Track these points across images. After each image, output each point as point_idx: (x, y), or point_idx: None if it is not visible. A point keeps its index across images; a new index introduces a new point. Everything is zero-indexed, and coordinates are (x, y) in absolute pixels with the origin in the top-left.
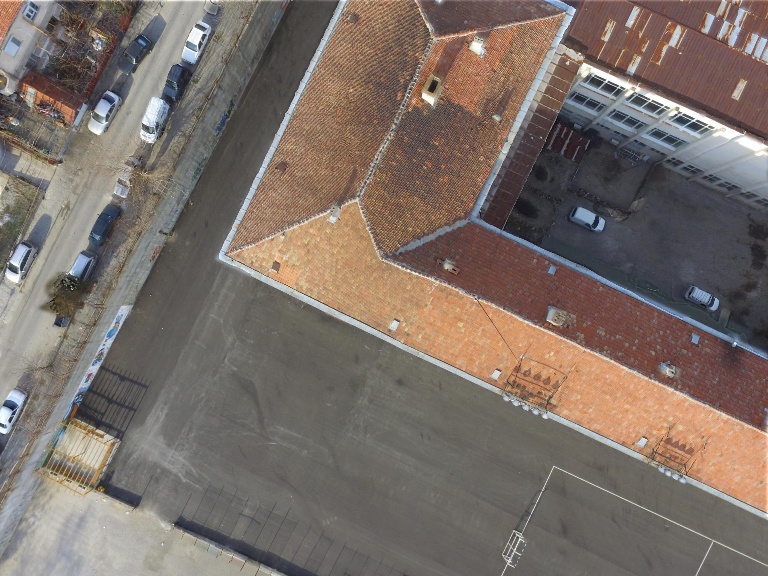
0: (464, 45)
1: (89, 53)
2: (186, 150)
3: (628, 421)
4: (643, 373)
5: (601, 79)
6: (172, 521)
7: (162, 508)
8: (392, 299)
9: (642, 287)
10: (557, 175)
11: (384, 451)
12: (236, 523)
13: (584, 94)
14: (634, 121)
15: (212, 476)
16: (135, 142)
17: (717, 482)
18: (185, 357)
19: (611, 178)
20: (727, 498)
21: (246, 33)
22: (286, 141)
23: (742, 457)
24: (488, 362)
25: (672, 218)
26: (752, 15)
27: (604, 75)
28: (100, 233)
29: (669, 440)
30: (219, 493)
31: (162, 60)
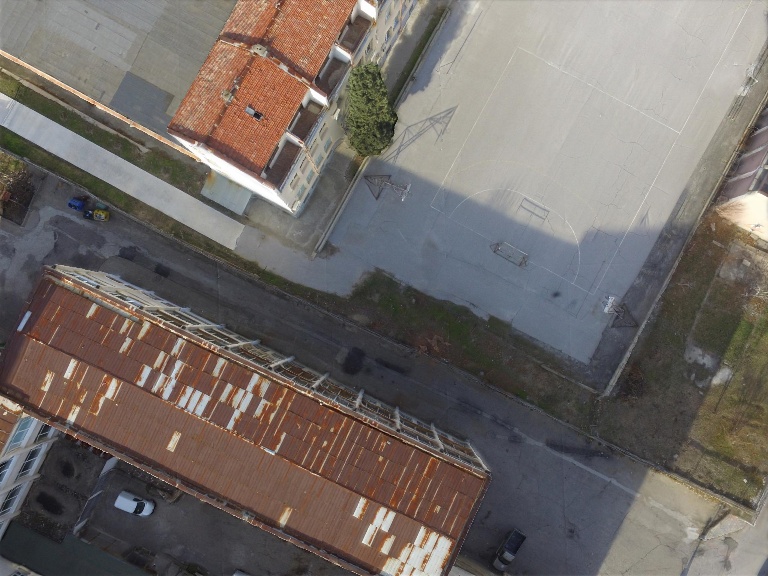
0: None
1: None
2: None
3: None
4: None
5: None
6: None
7: None
8: None
9: (190, 571)
10: (84, 471)
11: None
12: None
13: None
14: None
15: None
16: None
17: None
18: None
19: None
20: None
21: None
22: None
23: None
24: None
25: None
26: (189, 367)
27: None
28: None
29: None
30: None
31: None
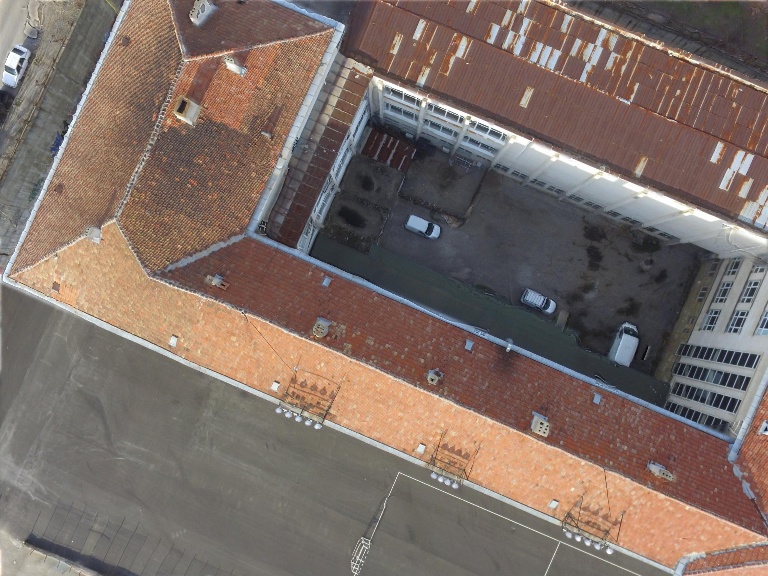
0: (220, 65)
1: None
2: (9, 172)
3: (404, 428)
4: (408, 381)
5: (398, 91)
6: (22, 539)
7: (12, 526)
8: (167, 316)
9: (480, 292)
10: (383, 185)
11: (230, 462)
12: (86, 539)
13: (394, 105)
14: (448, 130)
15: (61, 493)
16: None
17: (497, 486)
18: (31, 375)
19: (447, 185)
20: (509, 501)
21: (65, 55)
22: (64, 163)
23: (514, 461)
24: (266, 374)
25: (508, 223)
26: (537, 24)
27: (396, 87)
28: None
29: (445, 446)
30: (68, 509)
31: None
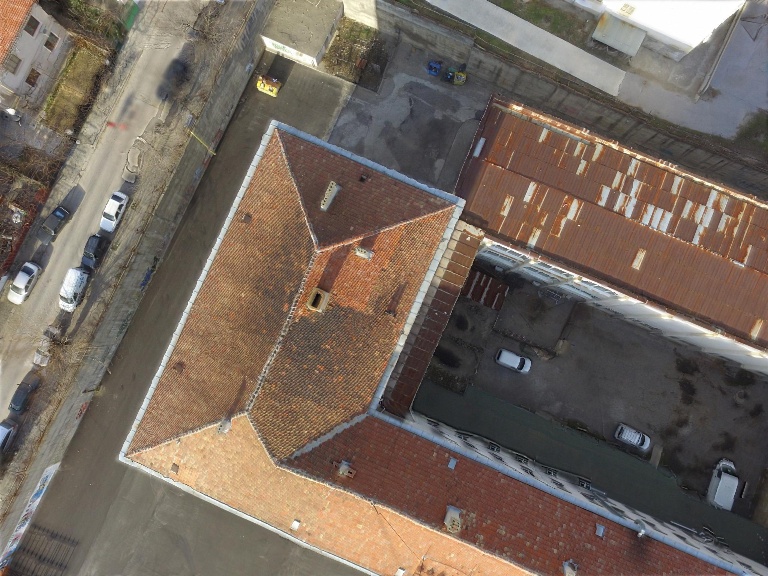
0: (350, 252)
1: (5, 232)
2: (105, 317)
3: None
4: (544, 575)
5: None
6: None
7: None
8: (290, 502)
9: (572, 426)
10: (477, 323)
11: None
12: None
13: None
14: None
15: None
16: (55, 309)
17: None
18: (113, 513)
19: (536, 317)
20: None
21: (163, 201)
22: (184, 340)
23: None
24: (391, 561)
25: (599, 355)
26: (647, 186)
27: (506, 247)
28: (19, 404)
29: None
30: None
31: (81, 228)
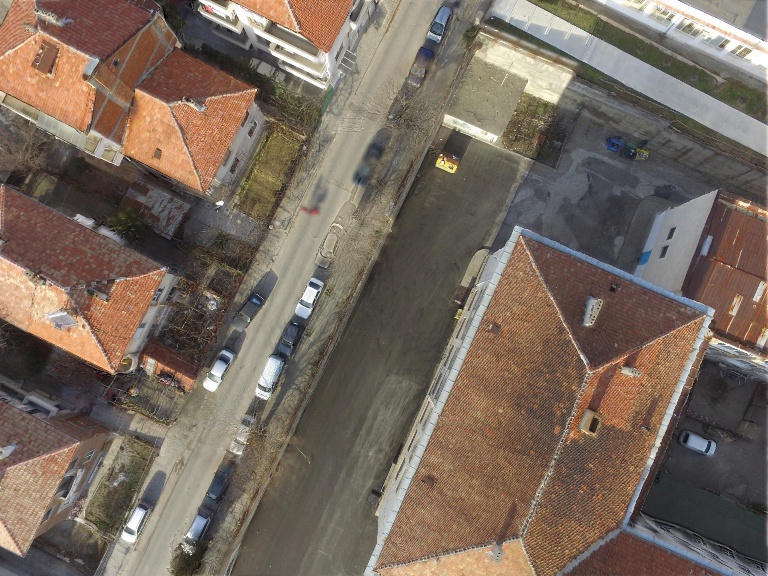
0: (617, 371)
1: (209, 323)
2: None
3: None
4: None
5: None
6: None
7: None
8: None
9: (758, 510)
10: None
11: None
12: None
13: None
14: (751, 364)
15: None
16: (249, 396)
17: None
18: None
19: (718, 397)
20: None
21: None
22: (431, 452)
23: None
24: None
25: None
26: None
27: (733, 347)
28: (217, 493)
29: None
30: None
31: (274, 314)
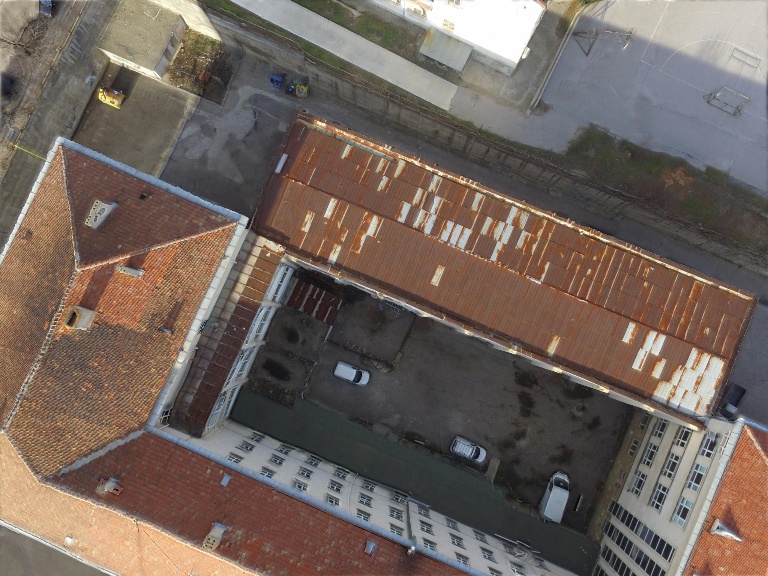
0: (116, 270)
1: None
2: None
3: None
4: None
5: None
6: None
7: None
8: (60, 518)
9: (409, 439)
10: (308, 337)
11: None
12: None
13: None
14: None
15: None
16: None
17: None
18: None
19: (377, 329)
20: None
21: None
22: None
23: None
24: None
25: (438, 368)
26: (448, 202)
27: None
28: None
29: None
30: None
31: None
